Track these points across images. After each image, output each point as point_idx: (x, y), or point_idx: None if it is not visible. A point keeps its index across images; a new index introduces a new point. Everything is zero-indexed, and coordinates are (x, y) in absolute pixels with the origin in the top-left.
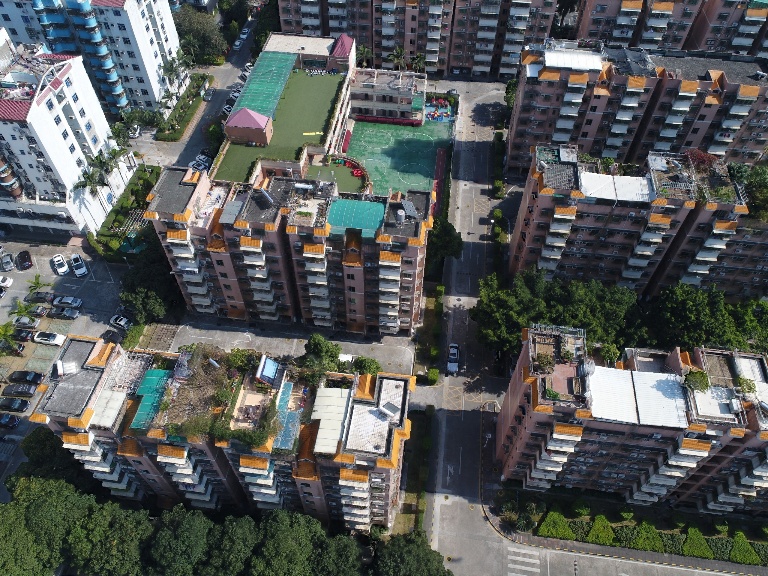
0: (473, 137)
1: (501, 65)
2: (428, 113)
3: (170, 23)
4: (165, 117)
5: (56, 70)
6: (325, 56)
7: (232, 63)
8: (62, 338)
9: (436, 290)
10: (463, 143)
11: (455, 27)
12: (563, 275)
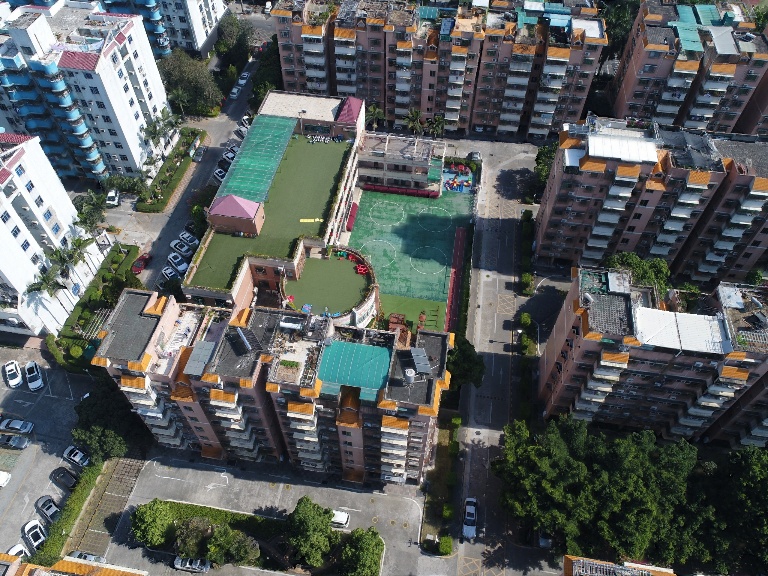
0: (497, 213)
1: (531, 125)
2: (446, 182)
3: (155, 77)
4: (148, 182)
5: (6, 156)
6: (329, 122)
7: (228, 114)
8: (5, 477)
9: (451, 422)
10: (486, 221)
11: (479, 83)
12: (605, 413)
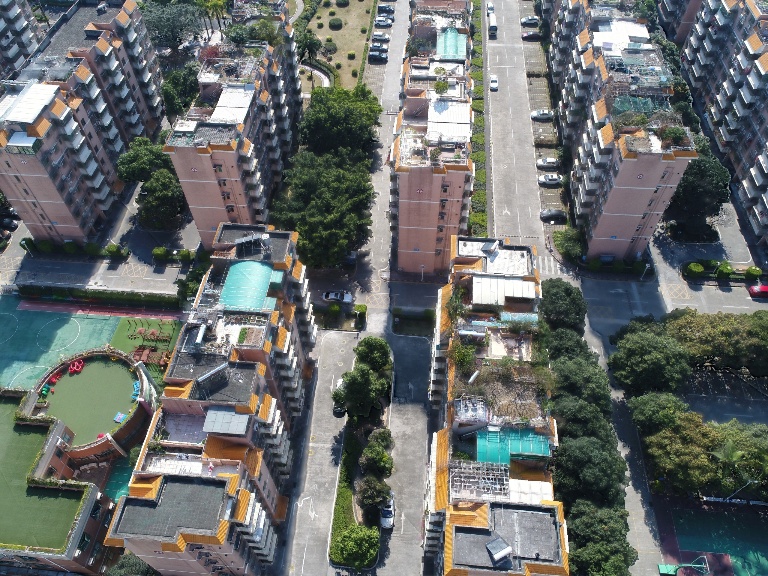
0: (9, 273)
1: None
2: None
3: None
4: None
5: None
6: None
7: None
8: None
9: None
10: (17, 283)
11: None
12: None
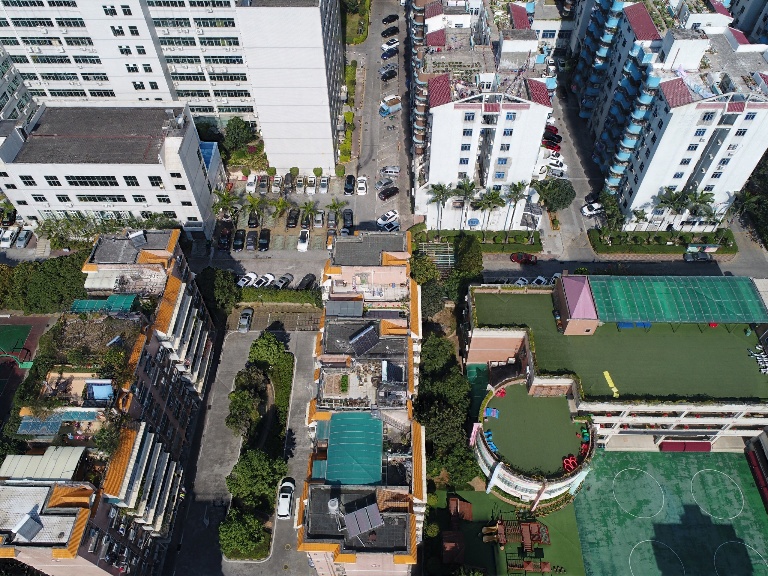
0: None
1: None
2: None
3: (745, 167)
4: (628, 228)
5: None
6: None
7: None
8: (304, 248)
9: None
10: None
11: None
12: None
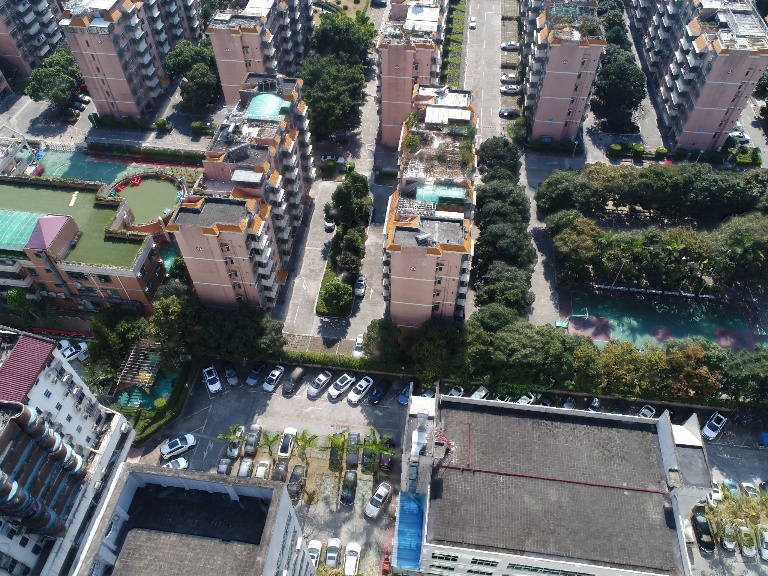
0: (79, 138)
1: None
2: None
3: None
4: None
5: None
6: None
7: None
8: (289, 429)
9: None
10: None
11: None
12: None
